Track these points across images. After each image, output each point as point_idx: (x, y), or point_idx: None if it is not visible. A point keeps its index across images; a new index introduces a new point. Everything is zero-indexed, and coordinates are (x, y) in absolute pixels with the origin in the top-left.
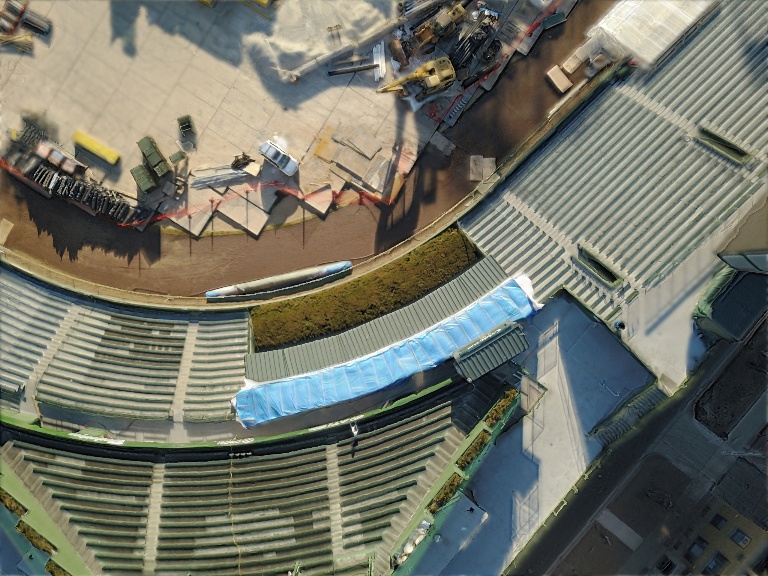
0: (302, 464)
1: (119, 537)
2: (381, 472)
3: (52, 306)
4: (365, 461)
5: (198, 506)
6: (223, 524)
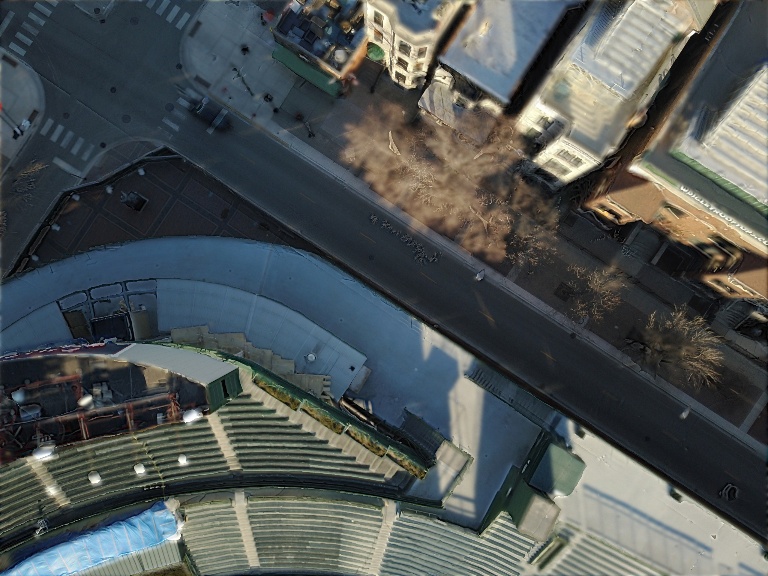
0: (90, 487)
1: (247, 418)
2: (1, 497)
3: (396, 574)
4: (24, 499)
5: (180, 446)
6: (147, 437)
